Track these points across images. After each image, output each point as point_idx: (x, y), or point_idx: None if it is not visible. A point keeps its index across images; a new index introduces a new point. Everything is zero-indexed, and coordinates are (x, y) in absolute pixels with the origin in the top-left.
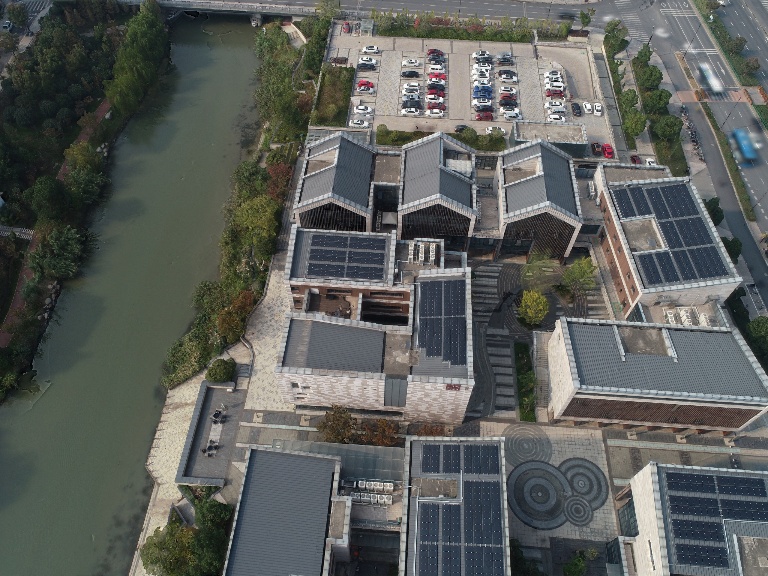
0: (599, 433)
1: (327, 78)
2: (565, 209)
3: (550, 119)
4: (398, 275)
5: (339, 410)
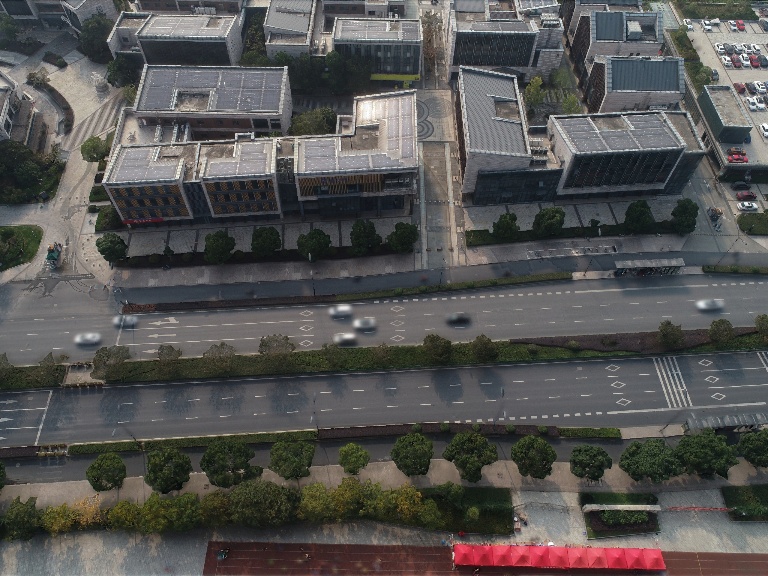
0: (452, 140)
1: (729, 0)
2: (615, 78)
3: (761, 124)
4: (529, 16)
5: (441, 22)
